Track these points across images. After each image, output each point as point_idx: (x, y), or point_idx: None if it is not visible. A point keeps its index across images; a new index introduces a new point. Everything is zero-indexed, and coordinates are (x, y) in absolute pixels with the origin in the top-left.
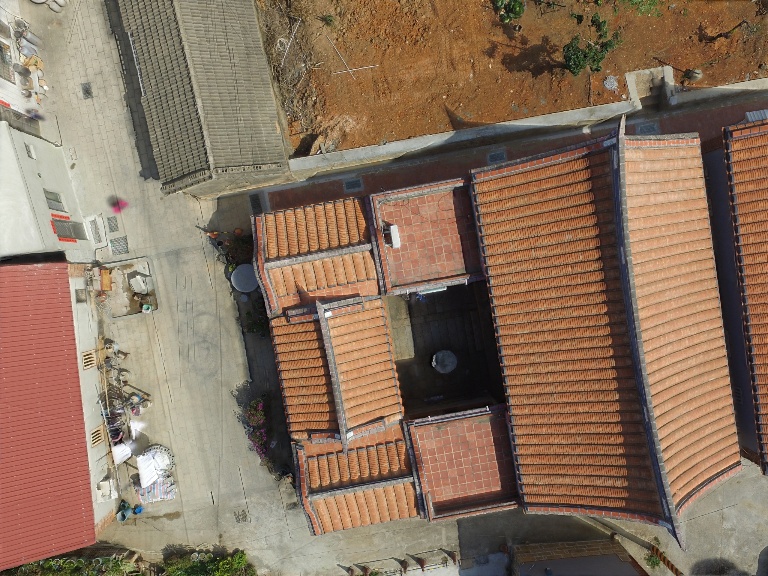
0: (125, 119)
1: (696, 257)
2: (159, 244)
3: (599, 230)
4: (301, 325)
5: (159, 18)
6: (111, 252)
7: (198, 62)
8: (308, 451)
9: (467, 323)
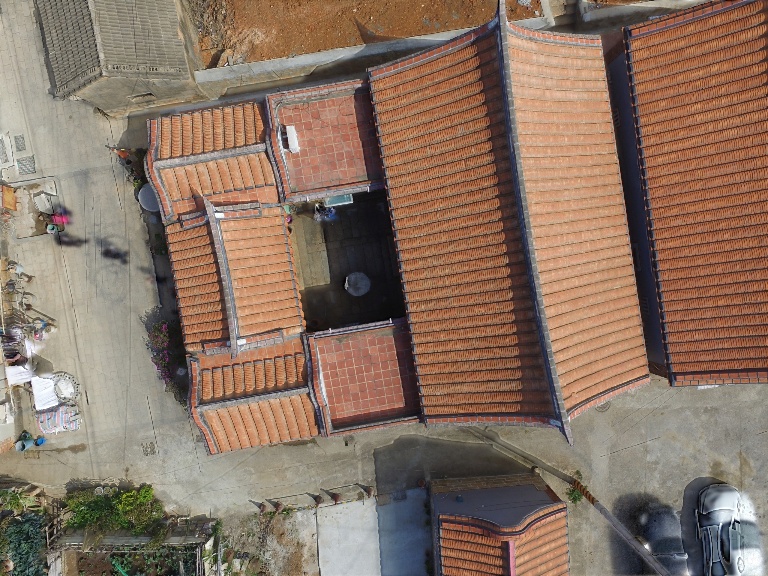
0: (34, 35)
1: (599, 161)
2: (67, 164)
3: (489, 120)
4: (195, 229)
5: None
6: (17, 172)
7: None
8: (203, 364)
9: (384, 248)
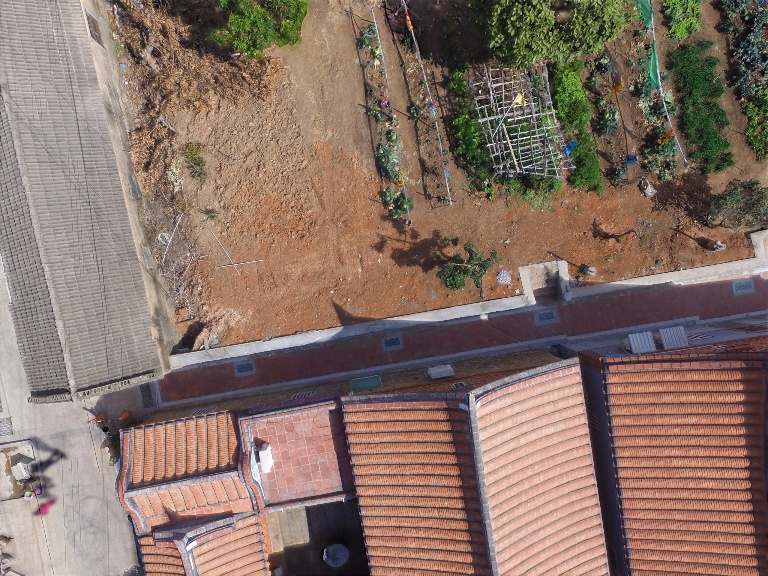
0: None
1: (575, 487)
2: (45, 425)
3: (462, 482)
4: (168, 549)
5: (21, 234)
6: None
7: (60, 282)
8: None
9: None
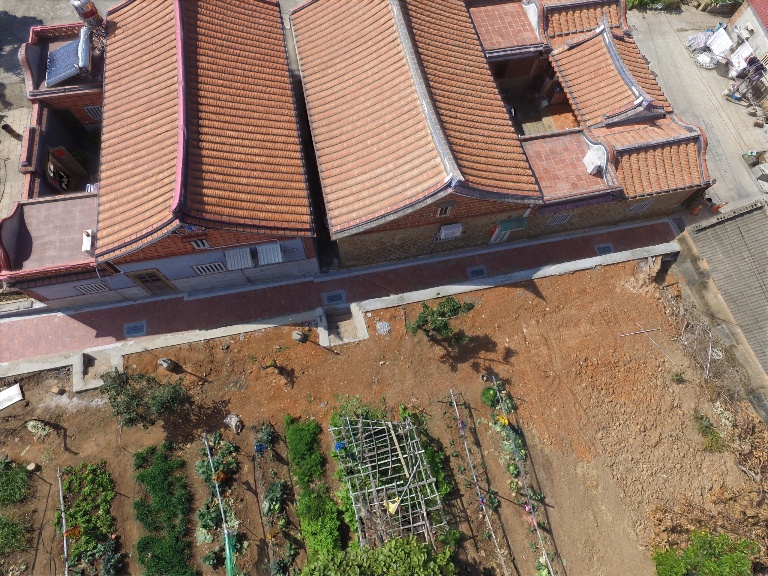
0: None
1: (334, 140)
2: None
3: (446, 131)
4: None
5: None
6: None
7: None
8: (620, 31)
9: None
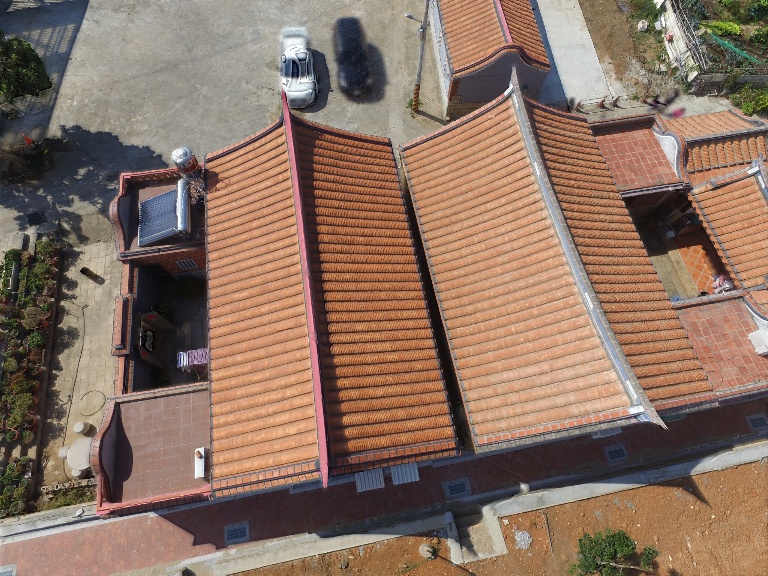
0: None
1: (468, 319)
2: None
3: (612, 328)
4: None
5: None
6: None
7: None
8: (767, 165)
9: None
